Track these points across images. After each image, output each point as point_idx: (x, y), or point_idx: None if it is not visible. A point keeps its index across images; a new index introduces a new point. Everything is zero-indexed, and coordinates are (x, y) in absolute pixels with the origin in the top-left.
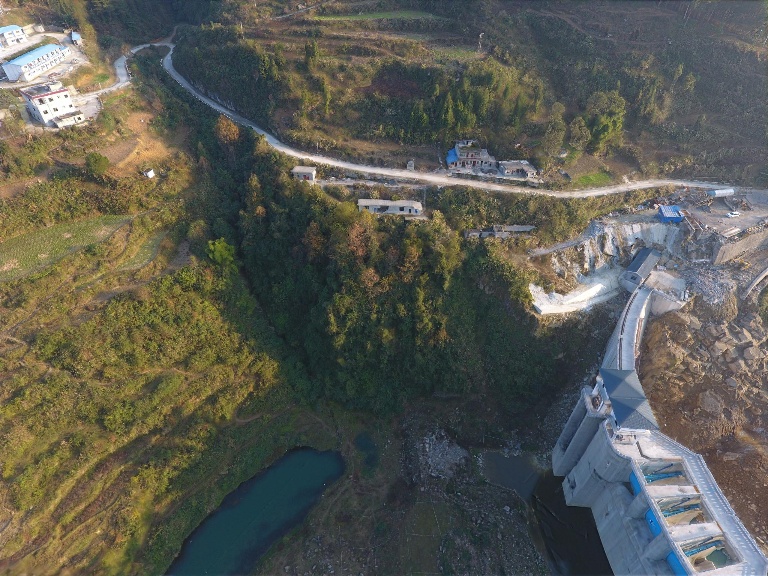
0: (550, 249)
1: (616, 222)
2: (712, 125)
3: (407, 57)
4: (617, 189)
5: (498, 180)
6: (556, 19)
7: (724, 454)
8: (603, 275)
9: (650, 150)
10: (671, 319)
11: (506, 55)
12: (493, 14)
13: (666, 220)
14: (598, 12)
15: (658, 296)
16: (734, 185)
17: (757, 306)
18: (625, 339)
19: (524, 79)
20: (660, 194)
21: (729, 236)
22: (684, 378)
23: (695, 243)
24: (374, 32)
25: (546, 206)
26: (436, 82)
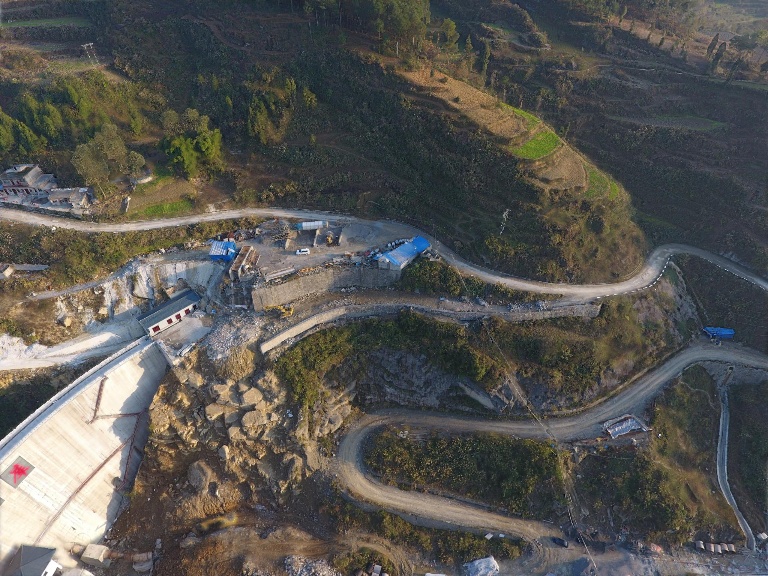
0: (61, 292)
1: (162, 260)
2: (336, 146)
3: (16, 70)
4: (187, 220)
5: (43, 210)
6: (200, 26)
7: (184, 539)
8: (124, 322)
9: (257, 174)
10: (171, 376)
11: (125, 67)
12: (129, 21)
13: (215, 258)
14: (238, 18)
15: (161, 349)
16: (347, 215)
17: (272, 362)
18: (54, 405)
19: (141, 94)
20: (241, 226)
21: (270, 278)
22: (177, 445)
23: (235, 286)
24: (6, 42)
25: (63, 242)
26: (15, 99)
